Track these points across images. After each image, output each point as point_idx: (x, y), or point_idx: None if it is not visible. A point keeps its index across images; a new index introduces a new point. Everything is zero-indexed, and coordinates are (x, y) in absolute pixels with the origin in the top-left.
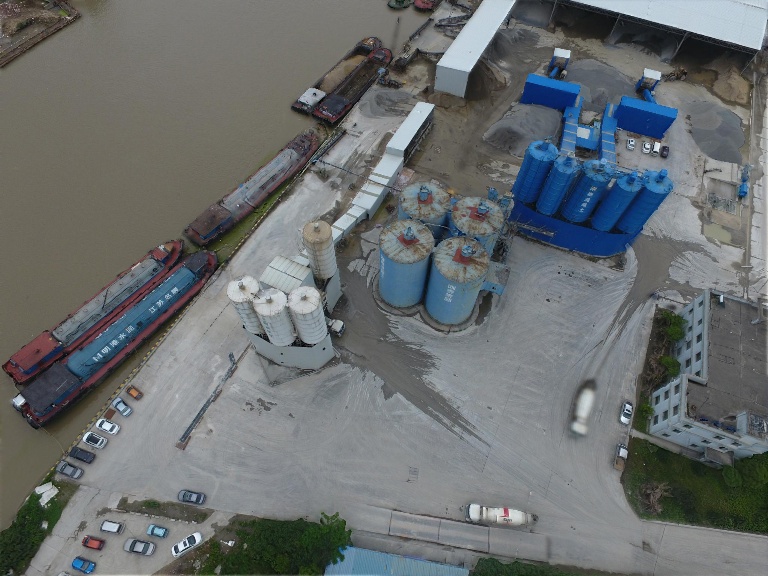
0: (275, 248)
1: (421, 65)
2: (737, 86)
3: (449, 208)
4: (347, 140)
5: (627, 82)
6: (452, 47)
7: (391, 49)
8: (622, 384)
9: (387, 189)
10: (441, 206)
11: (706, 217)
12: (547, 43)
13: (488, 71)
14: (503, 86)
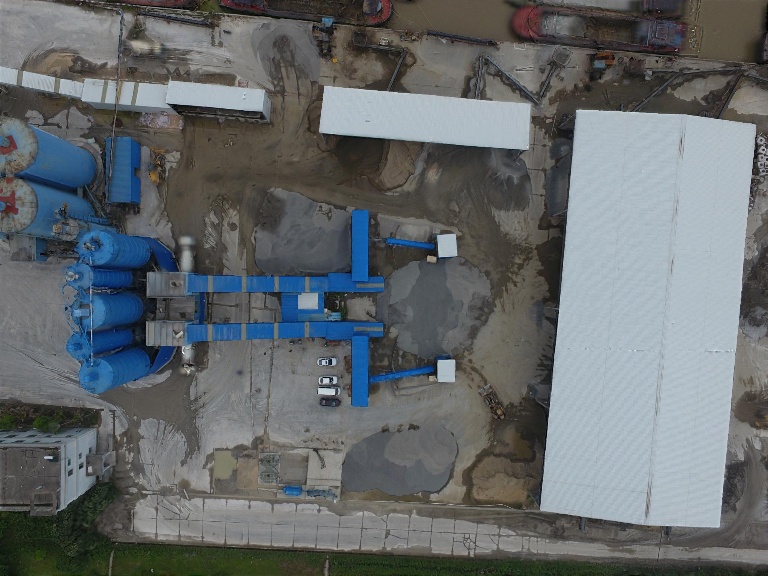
0: (22, 30)
1: (384, 69)
2: (494, 485)
3: (8, 174)
4: (202, 34)
5: (441, 343)
6: (374, 94)
7: (400, 16)
8: (6, 387)
9: (133, 108)
10: (5, 165)
11: (242, 453)
12: (509, 224)
13: (385, 159)
14: (381, 187)
